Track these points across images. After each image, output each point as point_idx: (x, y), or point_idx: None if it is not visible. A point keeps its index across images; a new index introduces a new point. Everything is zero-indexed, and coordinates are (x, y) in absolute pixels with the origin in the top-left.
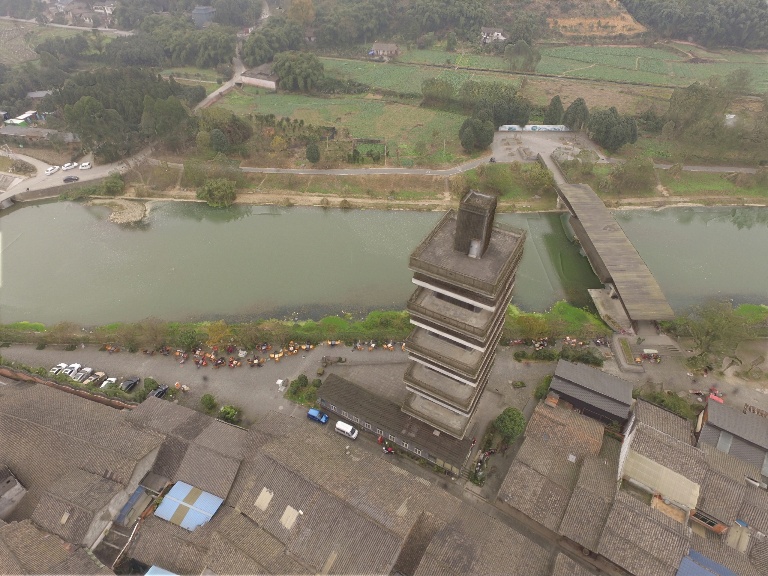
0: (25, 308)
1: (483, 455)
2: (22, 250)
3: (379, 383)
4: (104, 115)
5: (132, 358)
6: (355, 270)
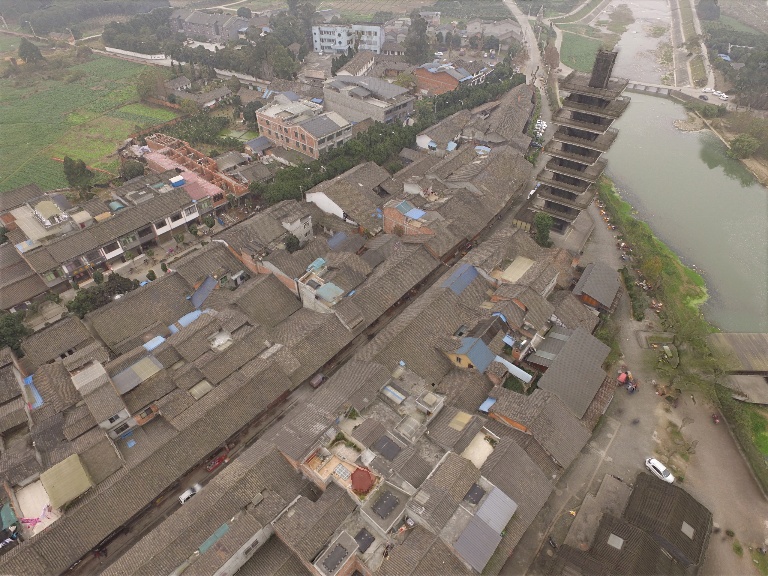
0: None
1: None
2: None
3: None
4: (767, 67)
5: None
6: (693, 216)
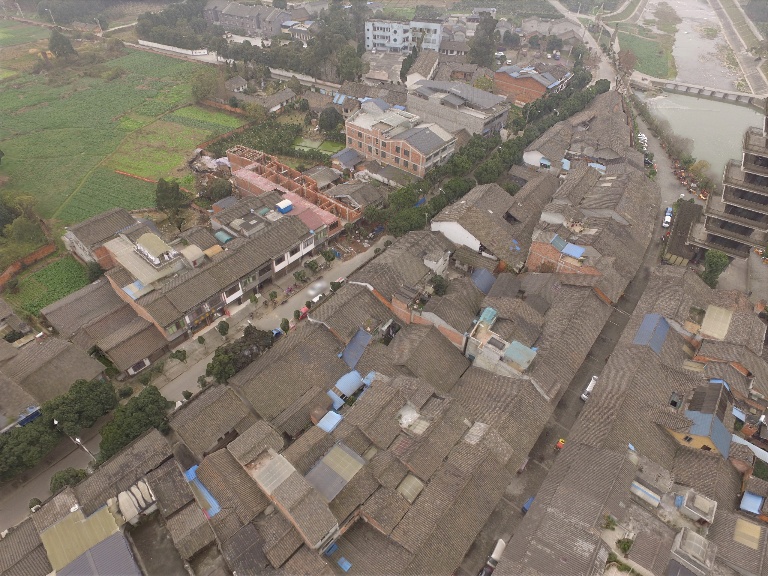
0: None
1: None
2: (711, 114)
3: None
4: None
5: (663, 153)
6: None
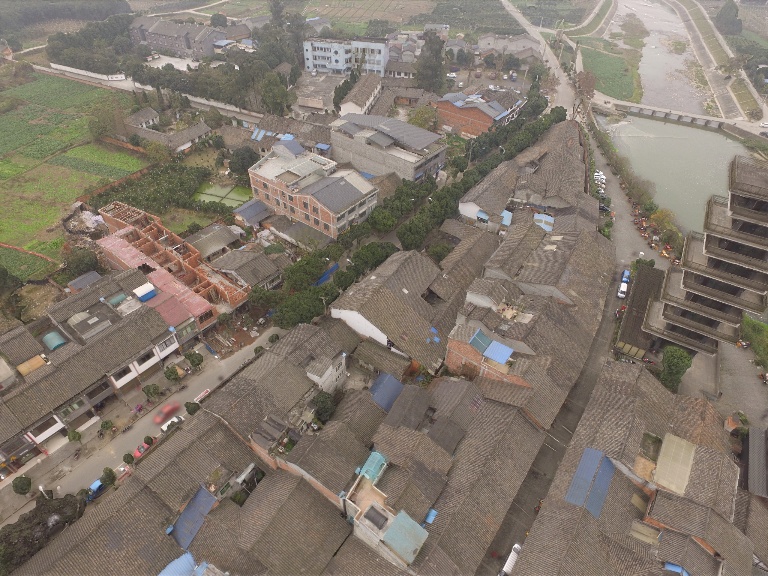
0: (633, 158)
1: (641, 364)
2: (678, 143)
3: None
4: None
5: (622, 196)
6: None
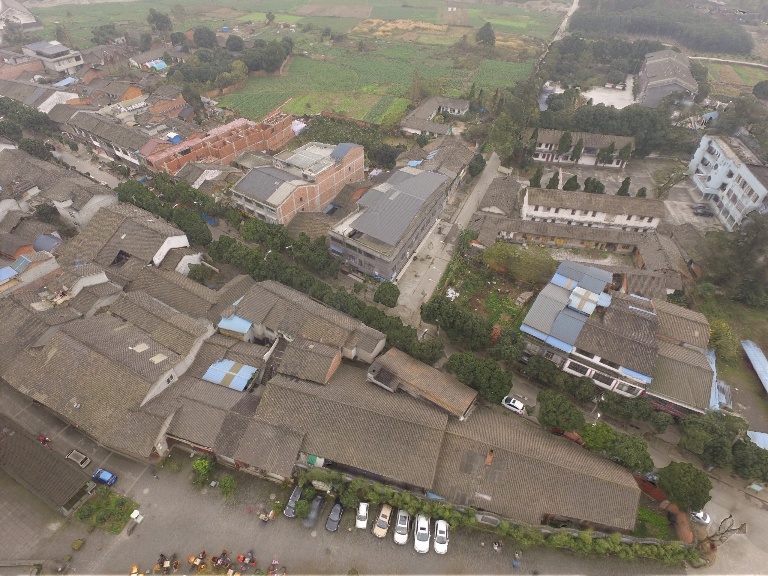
0: None
1: None
2: None
3: (5, 525)
4: None
5: None
6: None
